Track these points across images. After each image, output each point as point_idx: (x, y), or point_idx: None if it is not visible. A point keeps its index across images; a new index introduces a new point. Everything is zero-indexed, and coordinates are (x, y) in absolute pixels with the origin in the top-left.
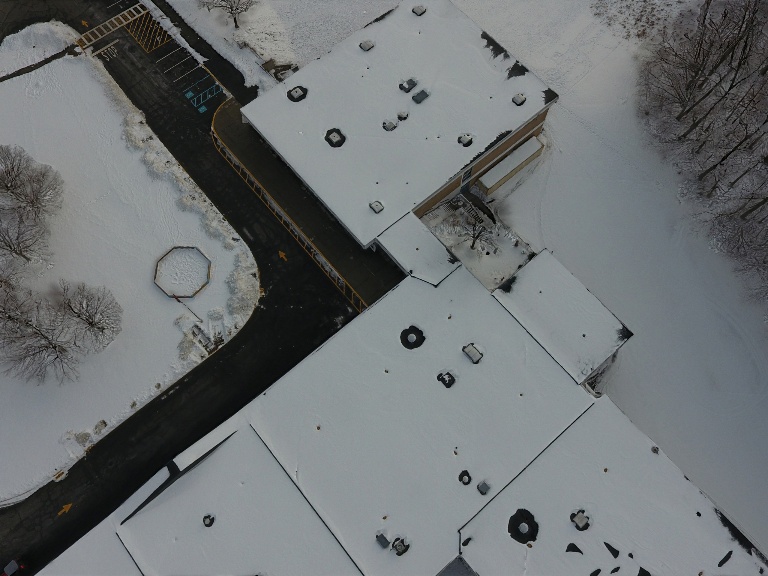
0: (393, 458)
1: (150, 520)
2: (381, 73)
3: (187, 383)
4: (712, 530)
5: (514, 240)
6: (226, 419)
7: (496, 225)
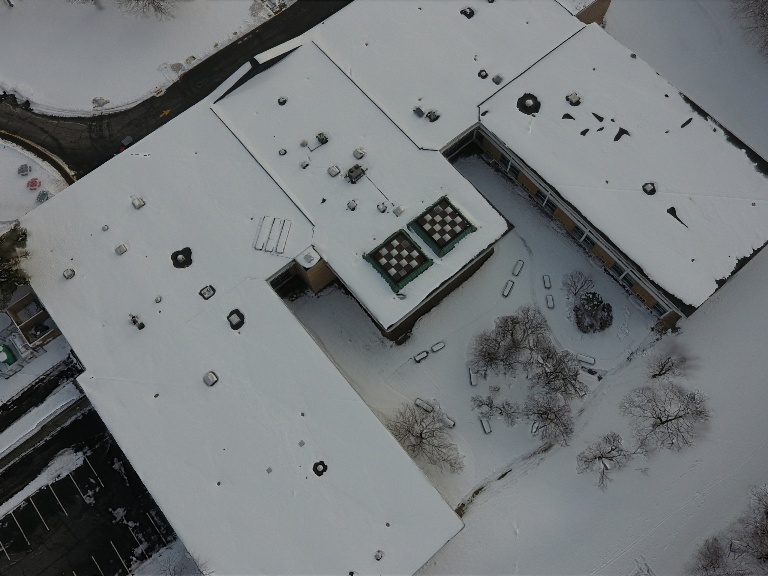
0: (426, 62)
1: (236, 101)
2: None
3: (258, 33)
4: (677, 105)
5: None
6: (293, 38)
7: None
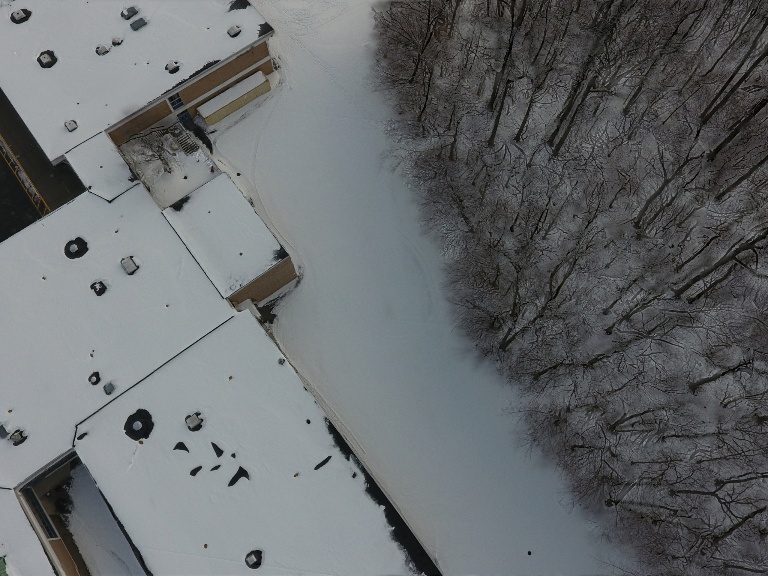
0: (30, 357)
1: None
2: (106, 0)
3: None
4: (317, 436)
5: (211, 166)
6: None
7: (198, 151)
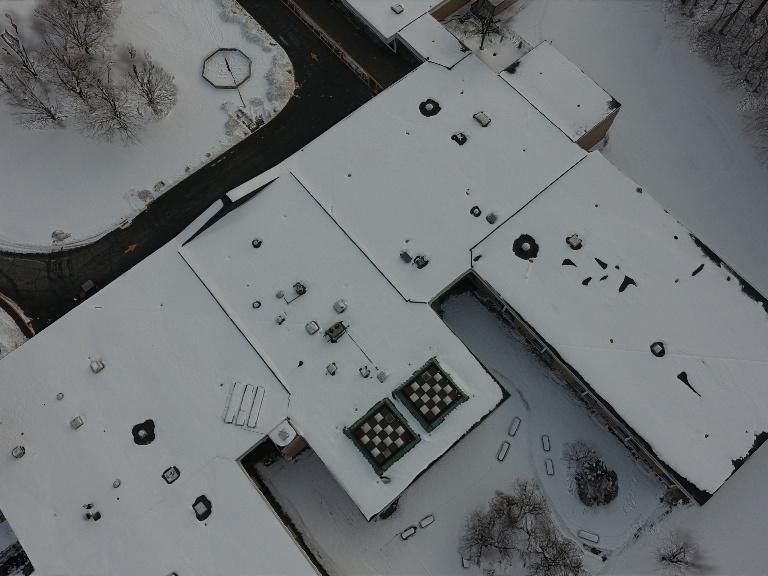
0: (414, 197)
1: (207, 243)
2: None
3: (233, 154)
4: (687, 249)
5: (518, 42)
6: (270, 168)
7: (502, 31)
